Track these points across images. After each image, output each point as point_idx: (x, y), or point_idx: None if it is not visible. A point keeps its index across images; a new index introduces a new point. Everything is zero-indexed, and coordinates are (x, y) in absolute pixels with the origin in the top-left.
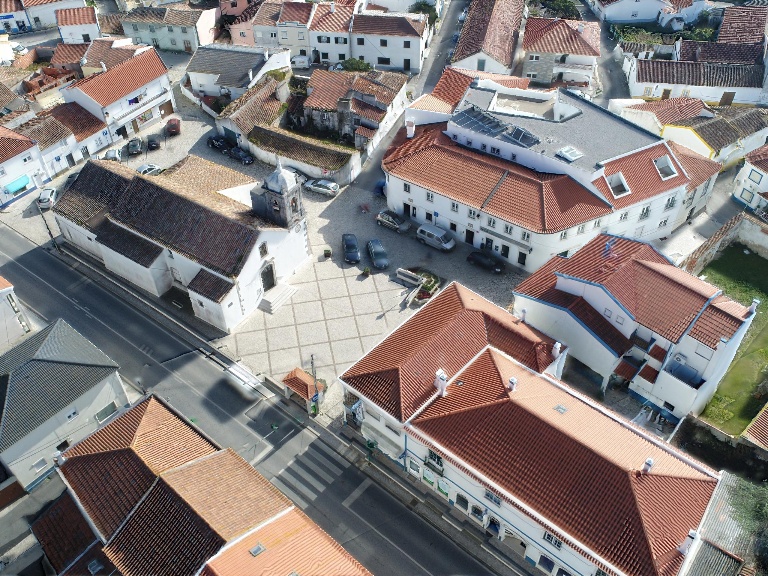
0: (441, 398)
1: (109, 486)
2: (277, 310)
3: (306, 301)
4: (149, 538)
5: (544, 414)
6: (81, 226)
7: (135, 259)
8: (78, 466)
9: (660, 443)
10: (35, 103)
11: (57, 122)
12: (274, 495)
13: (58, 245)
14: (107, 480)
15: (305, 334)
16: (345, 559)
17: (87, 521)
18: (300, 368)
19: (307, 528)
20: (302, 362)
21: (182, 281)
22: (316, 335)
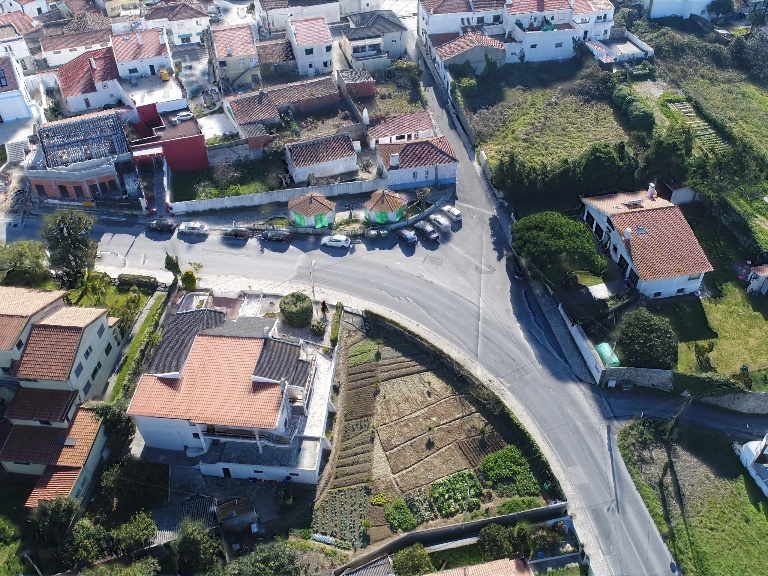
0: None
1: (455, 5)
2: (381, 6)
3: (383, 1)
4: (483, 1)
5: None
6: (289, 7)
7: (330, 2)
8: (439, 10)
9: None
10: (141, 8)
11: (185, 0)
12: None
13: (270, 32)
14: (452, 5)
15: (401, 4)
16: None
17: (448, 33)
18: None
19: None
20: (414, 7)
21: (342, 11)
22: (404, 3)
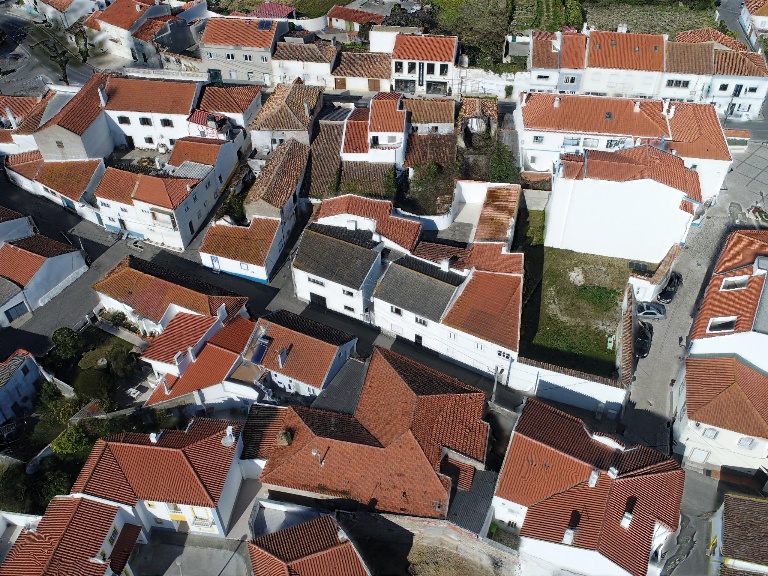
0: (662, 111)
1: None
2: None
3: None
4: None
5: (613, 104)
6: None
7: None
8: None
9: (558, 130)
10: None
11: None
12: (676, 70)
13: None
14: None
15: None
16: (630, 67)
17: None
18: (755, 154)
19: (652, 68)
20: (759, 156)
21: None
22: None
